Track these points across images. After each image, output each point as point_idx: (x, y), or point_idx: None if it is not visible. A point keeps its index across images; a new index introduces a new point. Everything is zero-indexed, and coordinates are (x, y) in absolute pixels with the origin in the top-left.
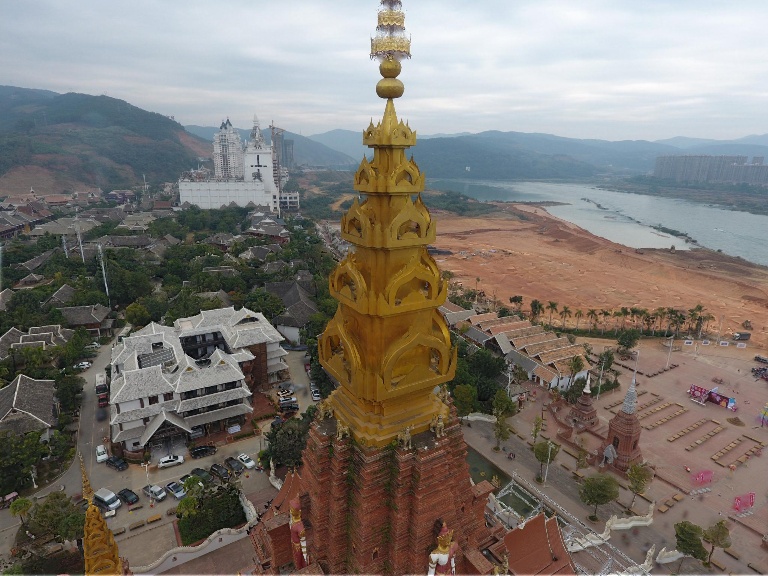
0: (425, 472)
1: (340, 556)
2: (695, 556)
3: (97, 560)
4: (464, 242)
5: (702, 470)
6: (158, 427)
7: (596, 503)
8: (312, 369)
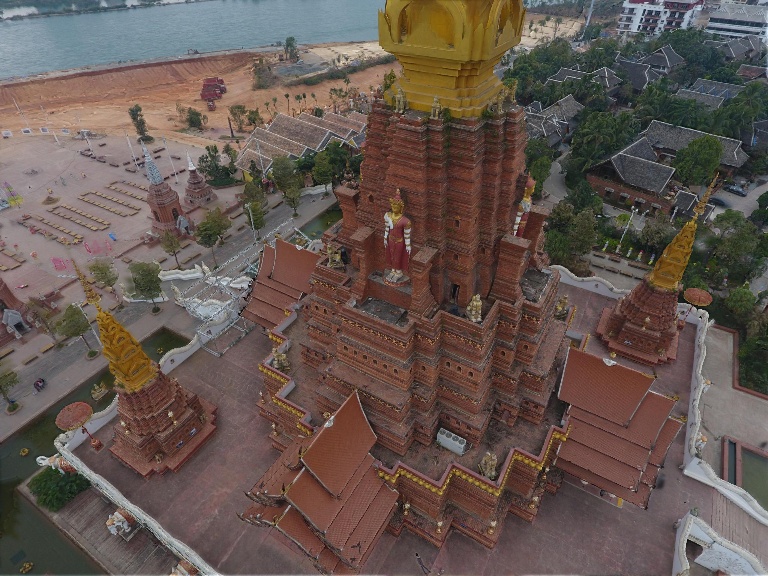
0: None
1: None
2: None
3: None
4: None
5: (25, 278)
6: None
7: (159, 288)
8: None
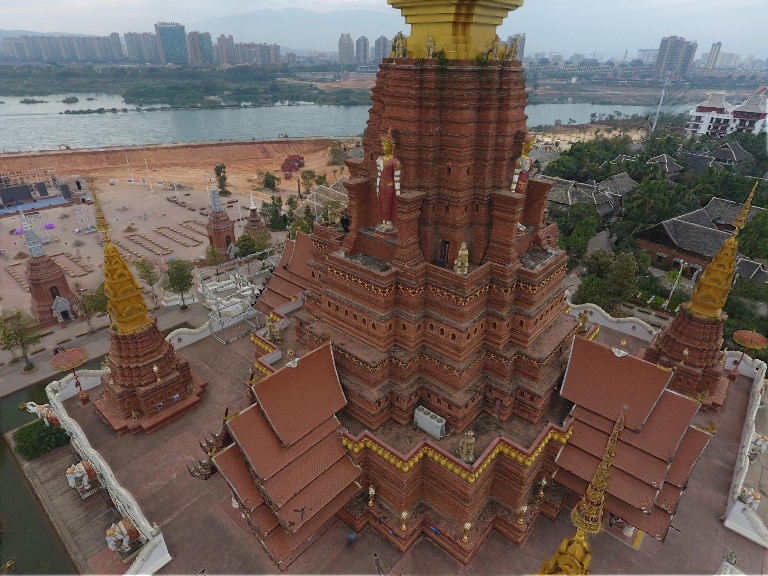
0: None
1: None
2: None
3: None
4: None
5: (87, 284)
6: None
7: (190, 285)
8: None
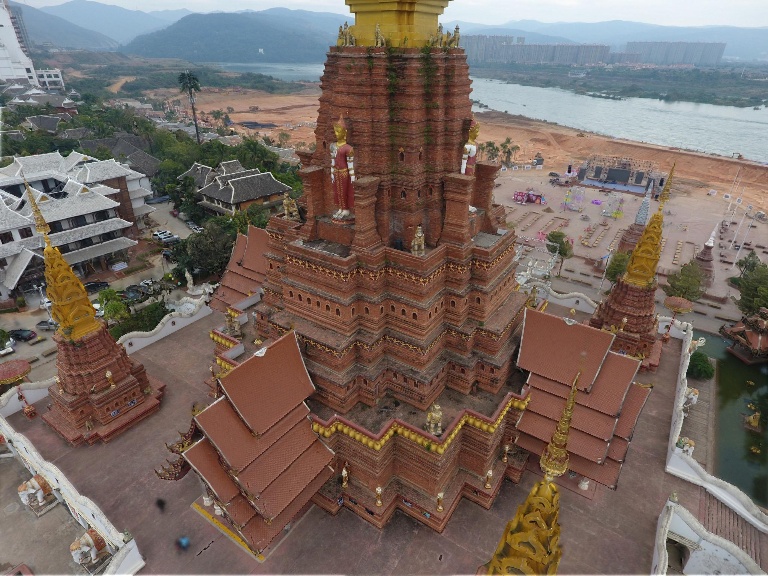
0: (458, 67)
1: (388, 167)
2: (561, 253)
3: (73, 306)
4: (285, 116)
5: None
6: (26, 265)
7: None
8: None
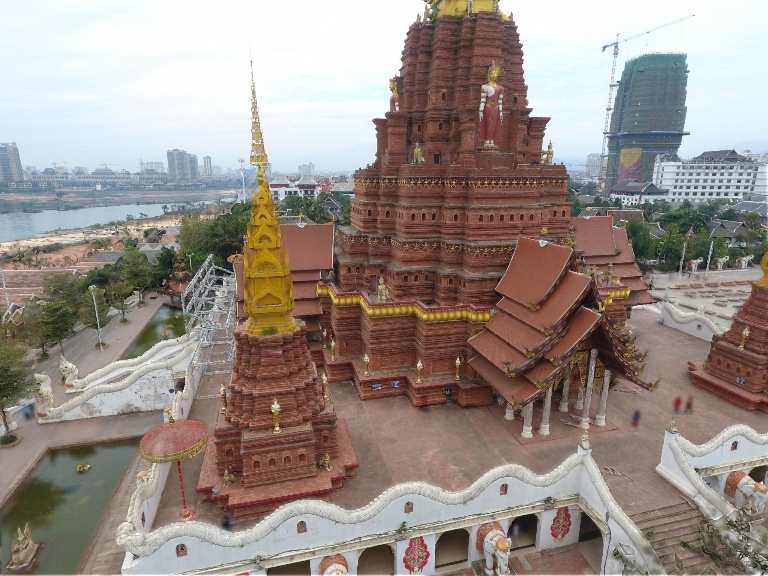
0: None
1: None
2: None
3: None
4: None
5: None
6: None
7: None
8: None
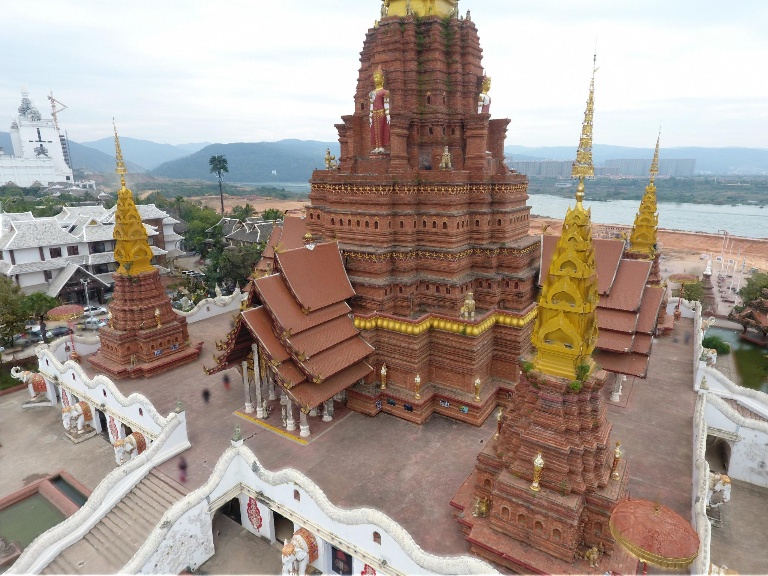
0: (471, 33)
1: (417, 109)
2: None
3: (136, 243)
4: None
5: None
6: (70, 276)
7: None
8: (209, 258)
